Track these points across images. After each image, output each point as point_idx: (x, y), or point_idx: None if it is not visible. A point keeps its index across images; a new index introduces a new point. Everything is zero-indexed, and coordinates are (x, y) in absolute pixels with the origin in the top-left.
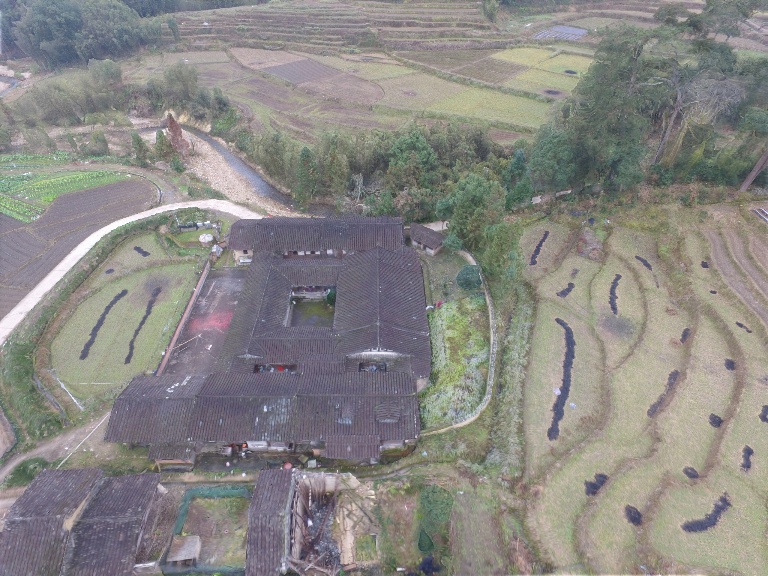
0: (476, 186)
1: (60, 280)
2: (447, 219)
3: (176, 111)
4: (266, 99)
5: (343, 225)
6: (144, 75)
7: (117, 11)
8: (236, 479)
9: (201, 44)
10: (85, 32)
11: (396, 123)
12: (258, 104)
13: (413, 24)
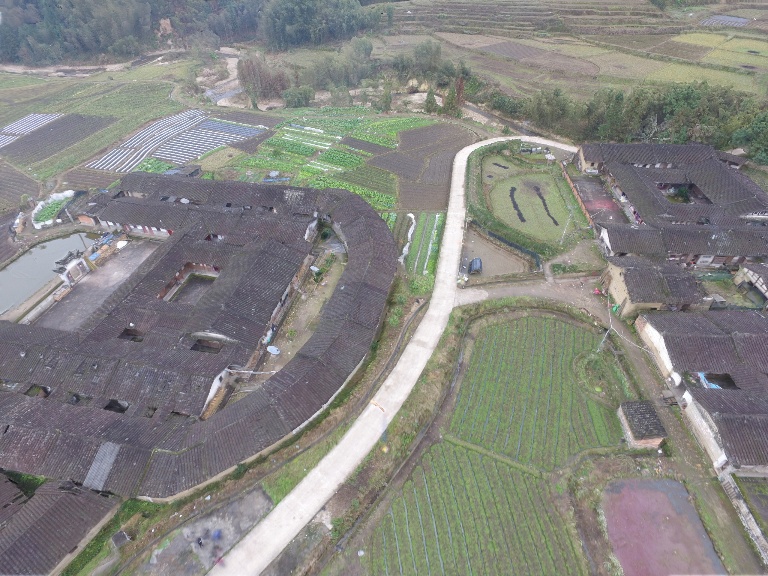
0: None
1: (469, 178)
2: (749, 144)
3: (419, 80)
4: (498, 70)
5: (668, 146)
6: (380, 52)
7: (346, 1)
8: None
9: (409, 29)
10: (320, 18)
11: (624, 88)
12: (495, 74)
13: (591, 13)
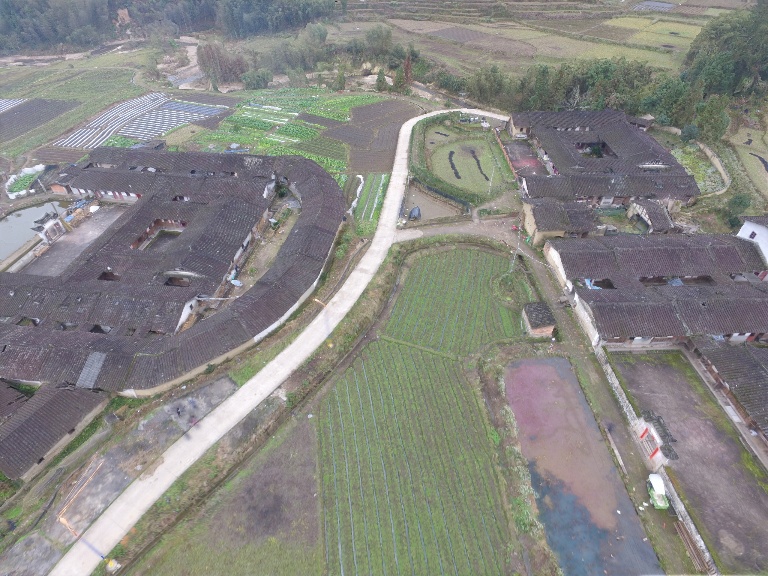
0: (677, 84)
1: (412, 144)
2: (654, 108)
3: (372, 63)
4: (445, 53)
5: (586, 112)
6: (335, 38)
7: None
8: None
9: (362, 16)
10: (276, 6)
11: (557, 67)
12: (442, 56)
13: None
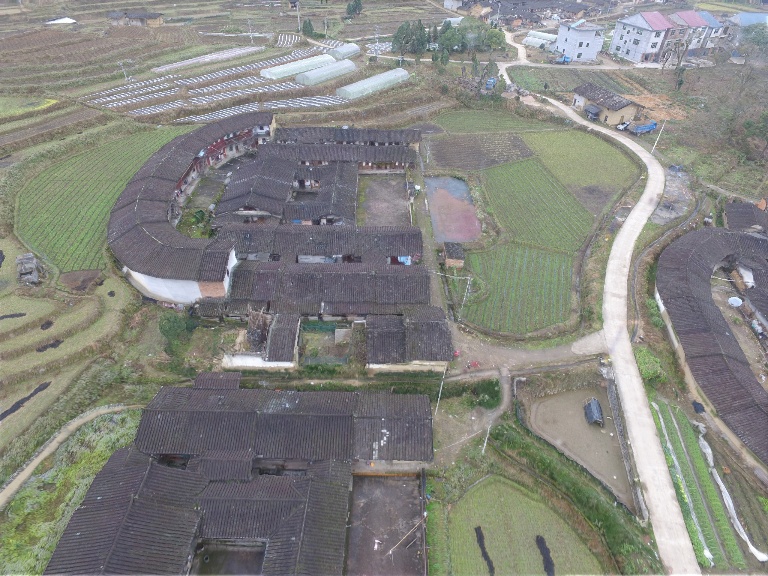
0: None
1: None
2: None
3: None
4: None
5: None
6: None
7: None
8: (318, 381)
9: None
10: None
11: None
12: None
13: None
